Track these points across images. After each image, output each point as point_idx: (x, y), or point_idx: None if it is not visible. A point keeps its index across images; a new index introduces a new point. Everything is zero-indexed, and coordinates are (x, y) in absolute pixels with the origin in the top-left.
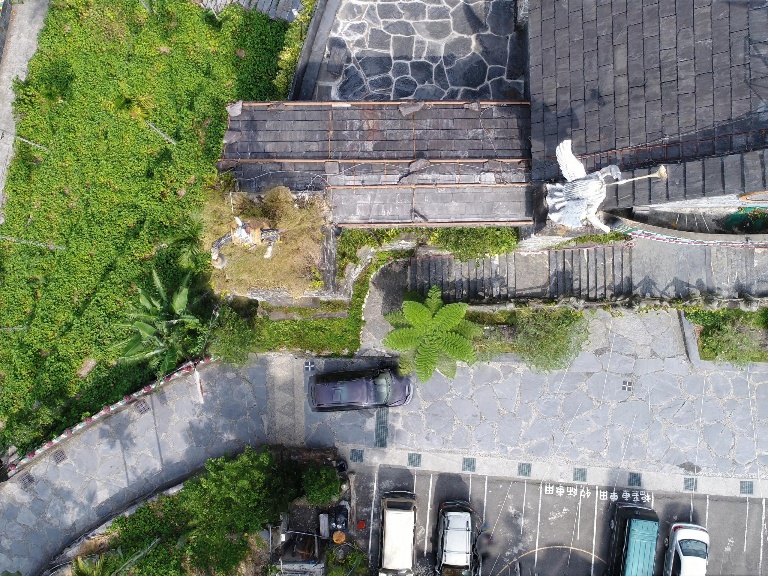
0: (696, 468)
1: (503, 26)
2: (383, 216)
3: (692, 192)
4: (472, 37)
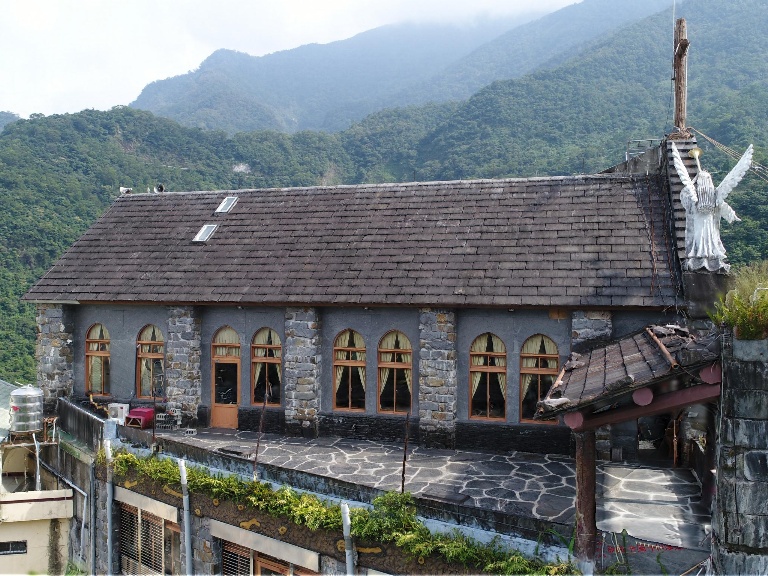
0: None
1: None
2: None
3: None
4: (450, 463)
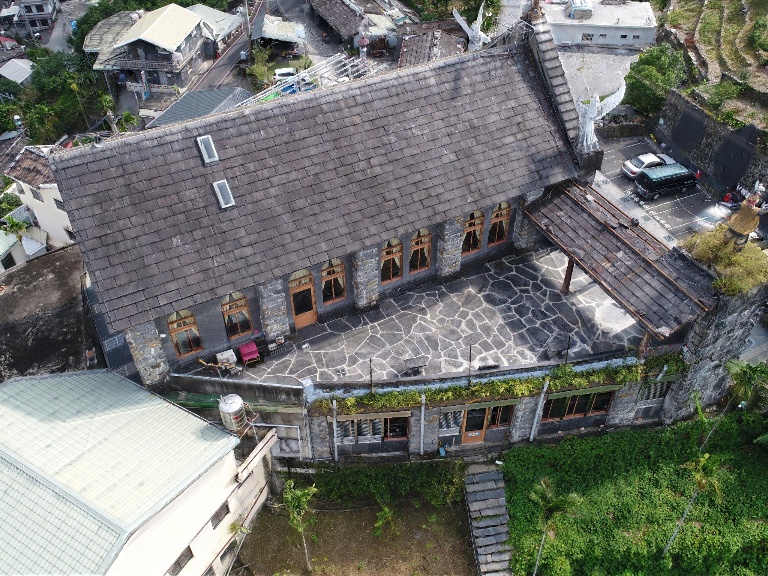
0: (596, 183)
1: (462, 285)
2: (650, 237)
3: (565, 80)
4: (481, 296)
